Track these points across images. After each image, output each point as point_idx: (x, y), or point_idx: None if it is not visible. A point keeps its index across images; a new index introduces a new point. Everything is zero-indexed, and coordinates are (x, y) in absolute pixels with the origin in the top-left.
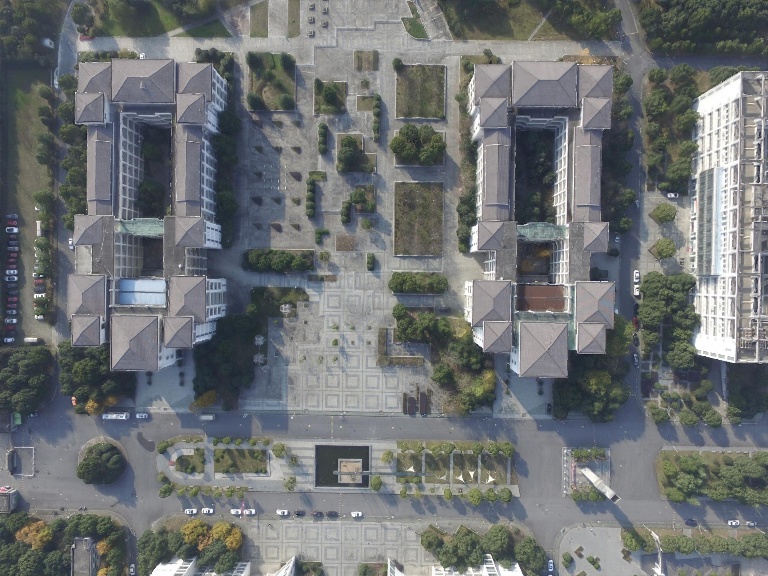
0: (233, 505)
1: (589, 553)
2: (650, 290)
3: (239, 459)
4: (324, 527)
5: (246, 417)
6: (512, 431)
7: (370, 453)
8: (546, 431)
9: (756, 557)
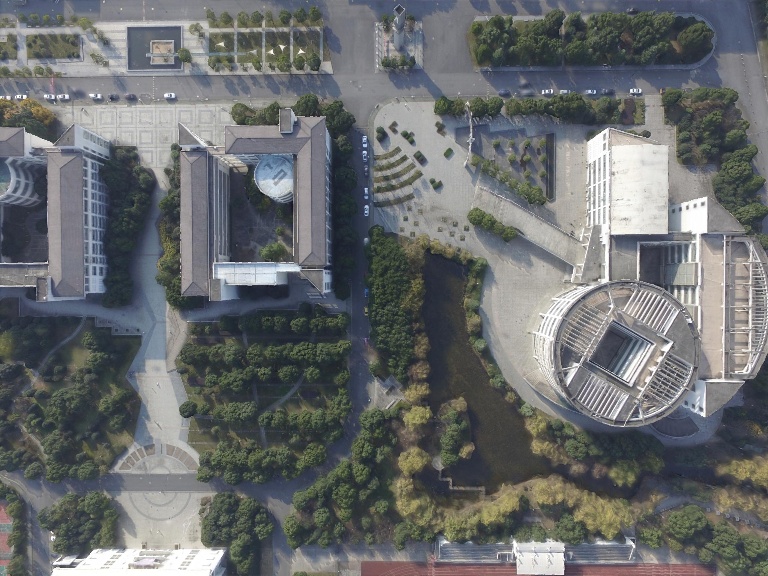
0: (47, 91)
1: (403, 128)
2: None
3: (51, 43)
4: (138, 111)
5: (58, 2)
6: (324, 7)
7: (182, 33)
8: (358, 5)
9: (571, 127)
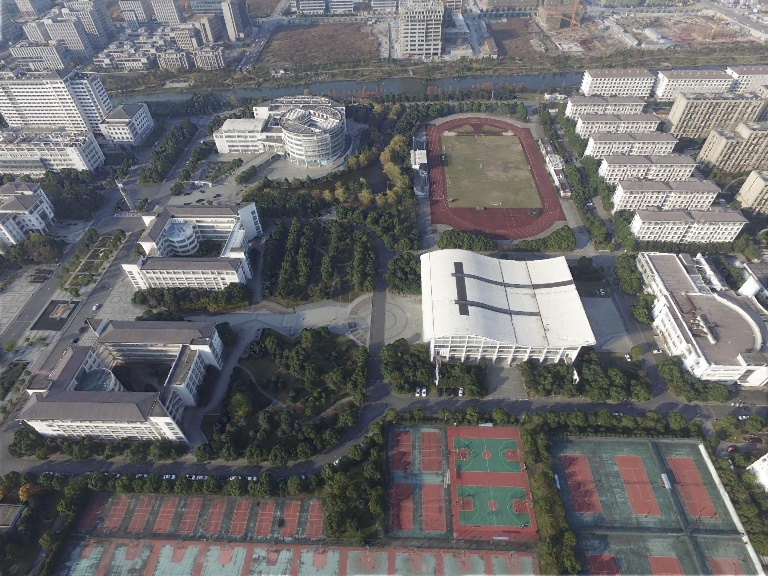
0: None
1: None
2: (40, 182)
3: (4, 381)
4: None
5: None
6: None
7: (57, 299)
8: (99, 222)
9: None
